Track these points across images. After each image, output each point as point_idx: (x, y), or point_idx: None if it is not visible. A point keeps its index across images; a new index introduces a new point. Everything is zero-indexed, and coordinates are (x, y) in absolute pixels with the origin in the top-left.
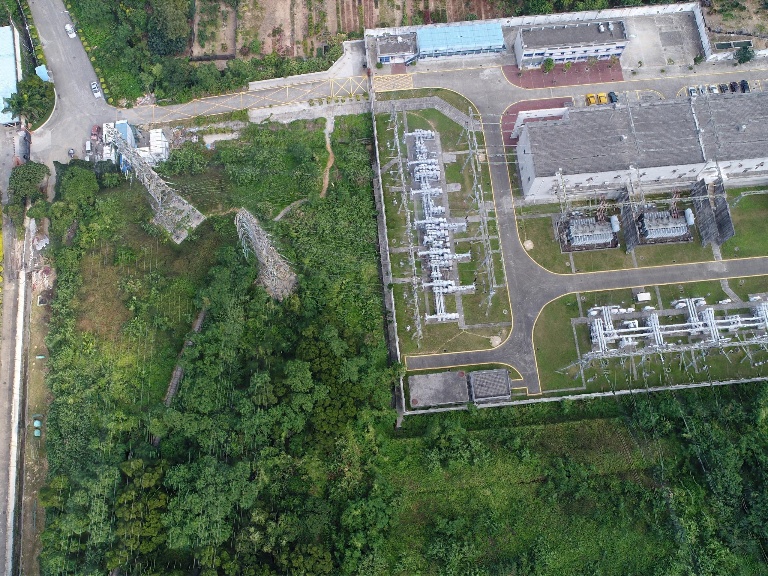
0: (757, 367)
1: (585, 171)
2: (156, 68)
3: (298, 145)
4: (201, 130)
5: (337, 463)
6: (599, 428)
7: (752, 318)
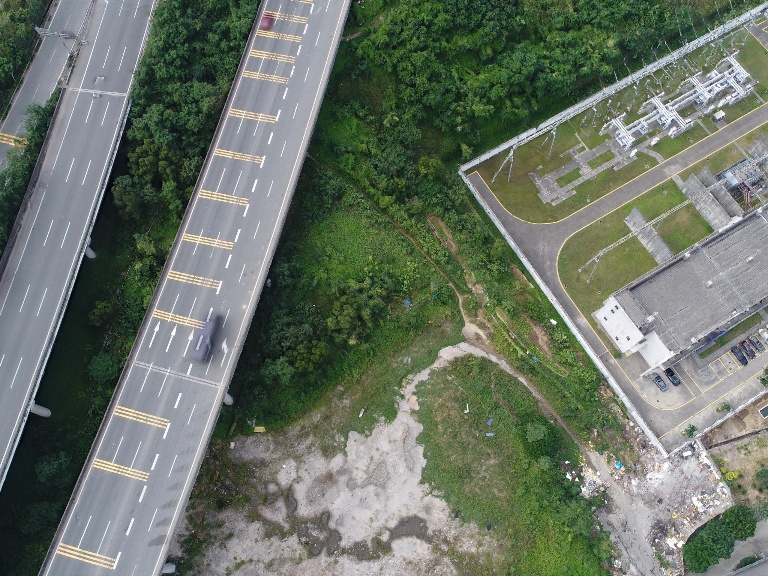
0: (606, 106)
1: None
2: None
3: None
4: None
5: None
6: (705, 4)
7: None
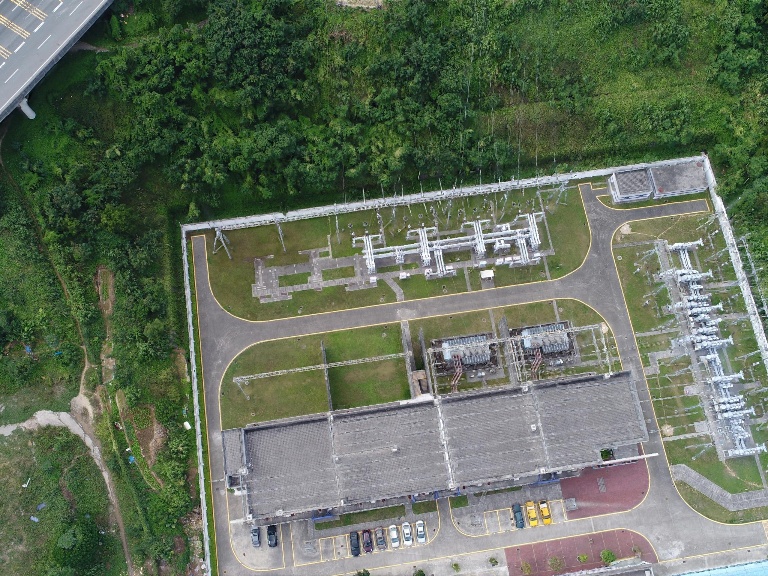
0: None
1: (574, 386)
2: None
3: None
4: None
5: (767, 102)
6: None
7: (384, 254)
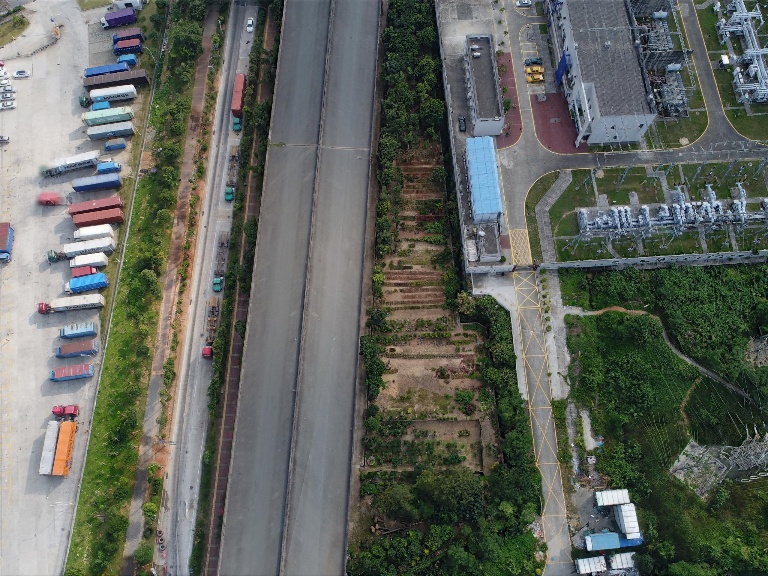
0: None
1: (641, 78)
2: (507, 509)
3: (623, 332)
4: (581, 453)
5: None
6: None
7: None
